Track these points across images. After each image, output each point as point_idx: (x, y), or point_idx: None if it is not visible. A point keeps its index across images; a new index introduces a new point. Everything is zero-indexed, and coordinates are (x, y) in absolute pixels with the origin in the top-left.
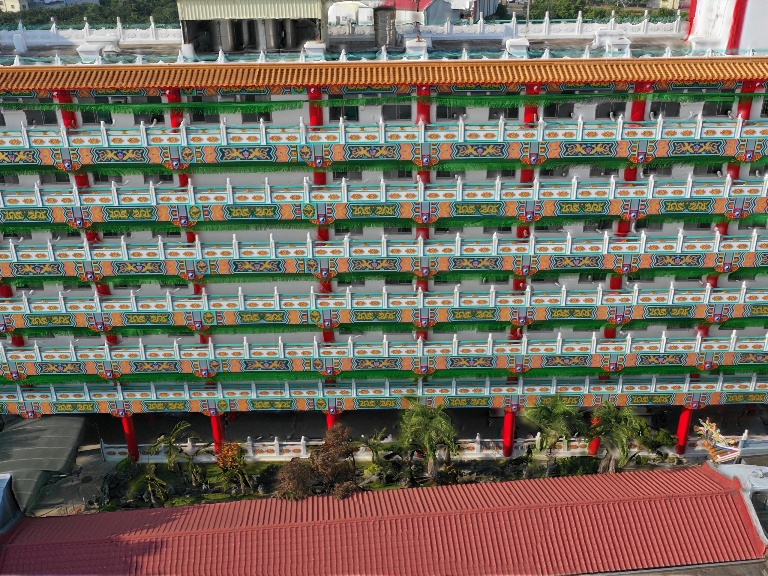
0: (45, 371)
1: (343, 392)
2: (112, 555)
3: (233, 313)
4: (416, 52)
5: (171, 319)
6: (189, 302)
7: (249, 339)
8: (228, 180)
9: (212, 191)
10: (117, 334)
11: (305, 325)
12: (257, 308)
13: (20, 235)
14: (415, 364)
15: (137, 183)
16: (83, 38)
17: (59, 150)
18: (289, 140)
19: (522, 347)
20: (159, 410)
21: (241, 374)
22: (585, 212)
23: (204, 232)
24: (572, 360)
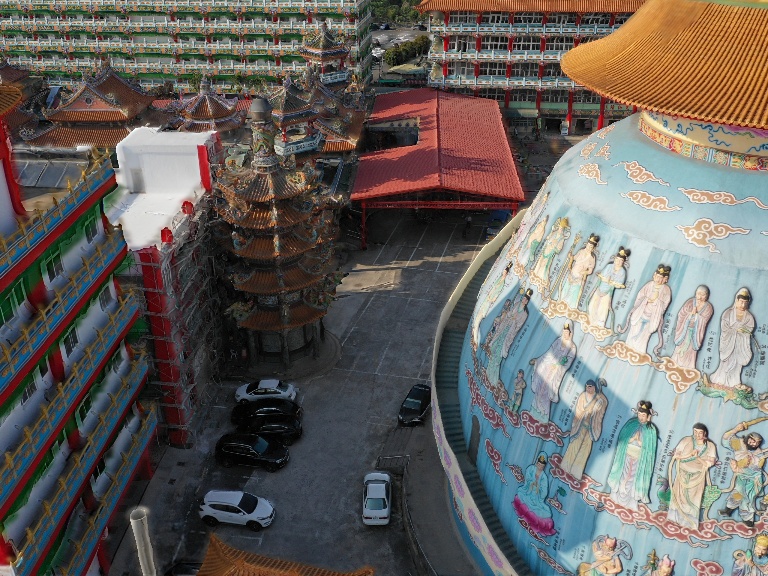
0: None
1: (184, 85)
2: None
3: (142, 48)
4: None
5: (122, 50)
6: (128, 44)
7: (149, 60)
8: None
9: (133, 0)
10: (105, 58)
11: (167, 54)
12: (151, 47)
13: (73, 18)
14: (207, 72)
15: None
16: None
17: None
18: None
19: (244, 66)
20: None
21: (147, 74)
22: (256, 11)
23: (132, 16)
24: (262, 72)
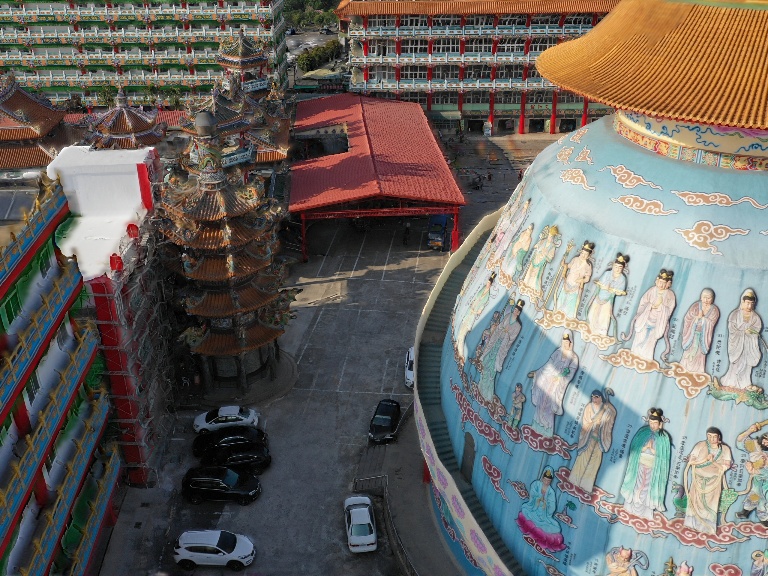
0: None
1: (92, 98)
2: None
3: (45, 60)
4: None
5: (22, 63)
6: (28, 56)
7: (52, 72)
8: (37, 6)
9: (32, 10)
10: (4, 72)
11: (72, 66)
12: (53, 58)
13: None
14: (116, 84)
15: (6, 8)
16: None
17: None
18: None
19: (156, 76)
20: None
21: (51, 88)
22: (166, 19)
23: (31, 27)
24: (176, 82)
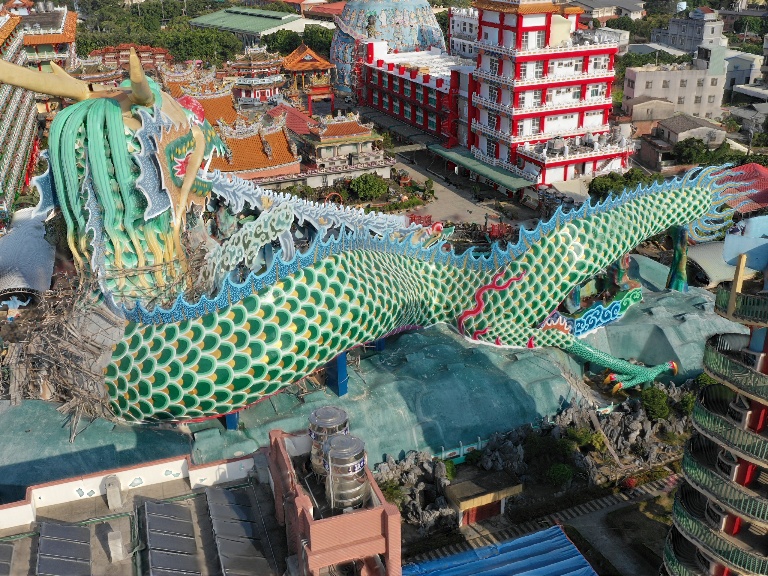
0: None
1: None
2: None
3: None
4: None
5: None
6: None
7: None
8: None
9: None
10: None
11: None
12: None
13: None
14: None
15: None
16: None
17: None
18: None
19: None
20: None
21: None
22: None
23: None
24: None
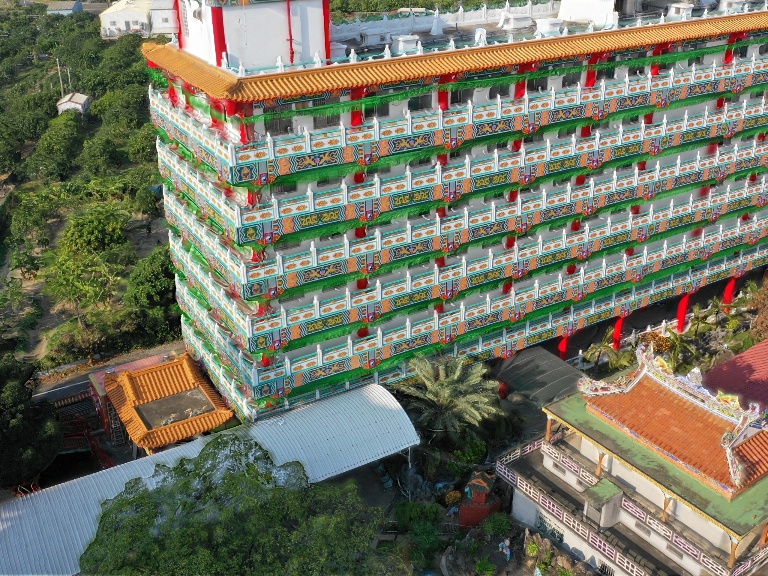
0: (538, 306)
1: (701, 273)
2: (763, 391)
3: (666, 222)
4: (739, 6)
5: (629, 236)
6: (641, 219)
7: (668, 242)
8: (687, 112)
9: (676, 122)
10: (576, 262)
11: (701, 221)
12: (679, 214)
13: (531, 188)
14: (751, 237)
15: None
16: (457, 20)
17: (598, 103)
18: (725, 75)
19: None
20: (594, 322)
21: (658, 273)
22: None
23: (663, 157)
24: None
